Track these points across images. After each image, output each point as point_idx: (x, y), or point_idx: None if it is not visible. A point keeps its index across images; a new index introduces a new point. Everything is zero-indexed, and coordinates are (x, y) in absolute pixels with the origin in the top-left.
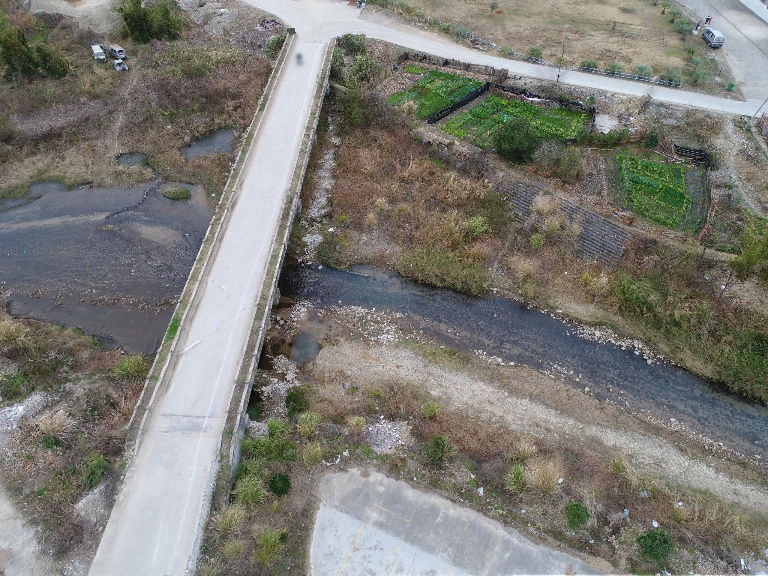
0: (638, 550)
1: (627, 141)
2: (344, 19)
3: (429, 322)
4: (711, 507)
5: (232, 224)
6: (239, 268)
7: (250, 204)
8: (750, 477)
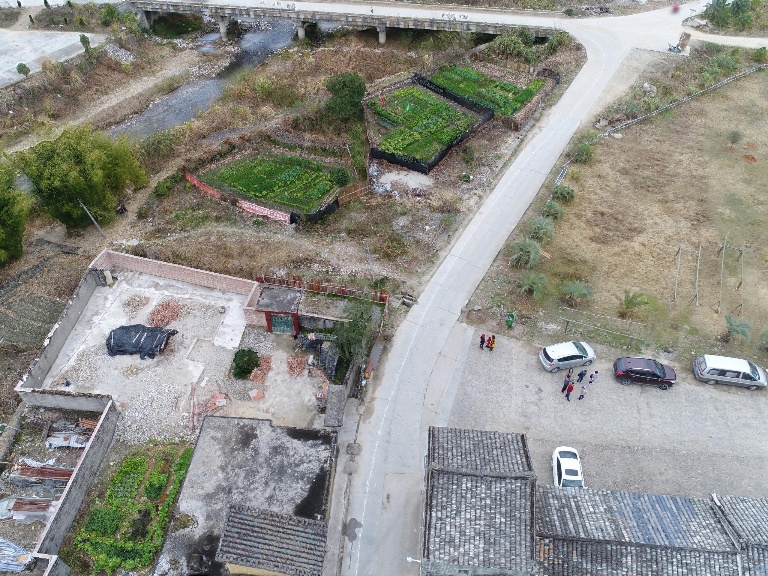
0: (2, 96)
1: (368, 182)
2: (626, 40)
3: (202, 85)
4: (2, 131)
5: (279, 1)
6: (238, 3)
7: (297, 4)
8: (8, 161)
